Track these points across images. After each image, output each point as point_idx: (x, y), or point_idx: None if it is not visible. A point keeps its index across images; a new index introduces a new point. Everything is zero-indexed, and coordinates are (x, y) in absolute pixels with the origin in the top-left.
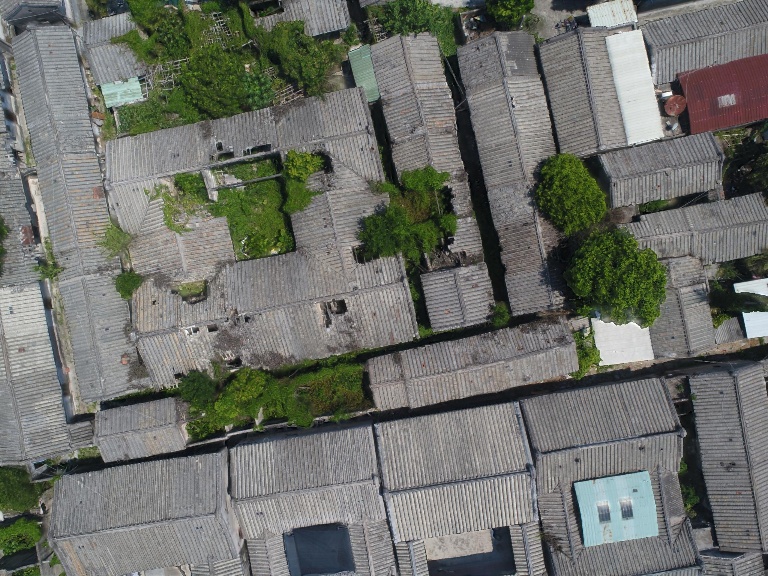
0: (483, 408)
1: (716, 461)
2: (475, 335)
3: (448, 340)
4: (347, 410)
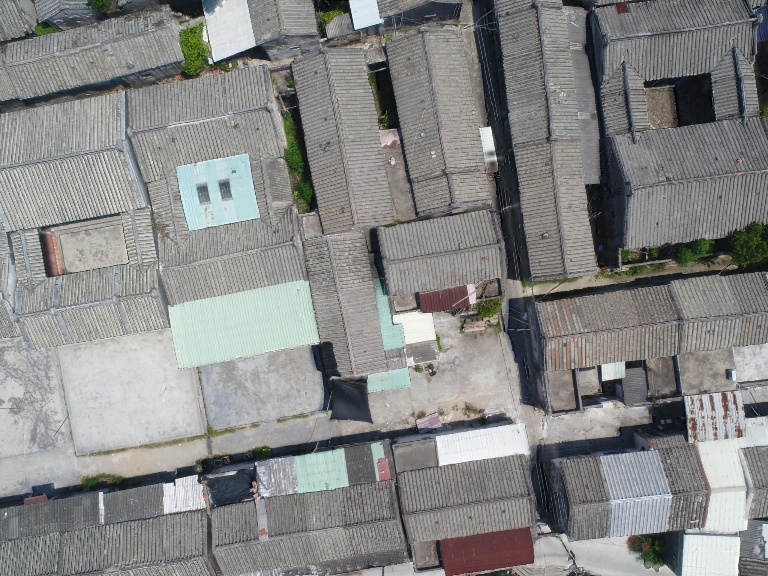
0: (91, 98)
1: (316, 144)
2: (82, 26)
3: (56, 32)
4: None
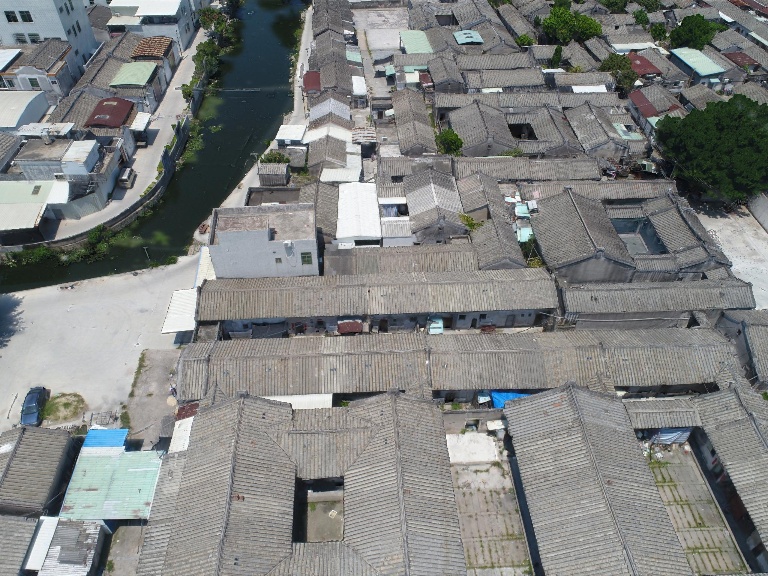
0: None
1: None
2: None
3: None
4: None
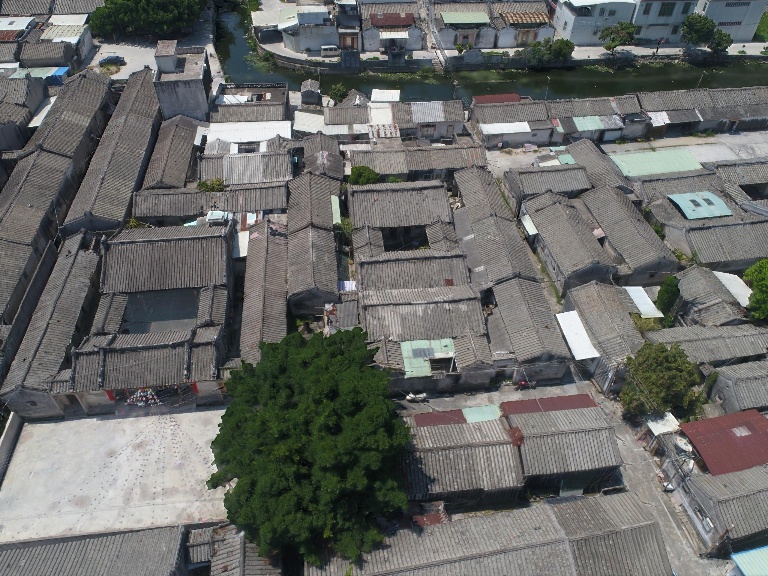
0: None
1: None
2: None
3: None
4: None
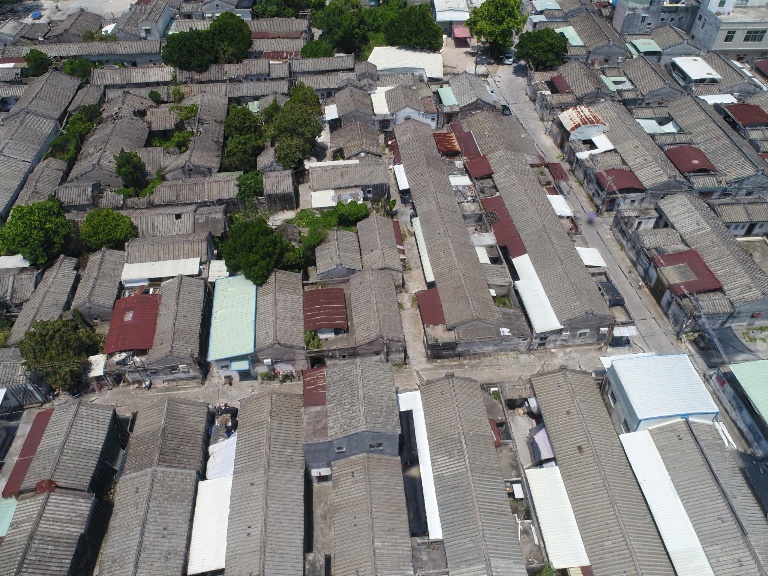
0: (8, 200)
1: None
2: None
3: None
4: (47, 158)
